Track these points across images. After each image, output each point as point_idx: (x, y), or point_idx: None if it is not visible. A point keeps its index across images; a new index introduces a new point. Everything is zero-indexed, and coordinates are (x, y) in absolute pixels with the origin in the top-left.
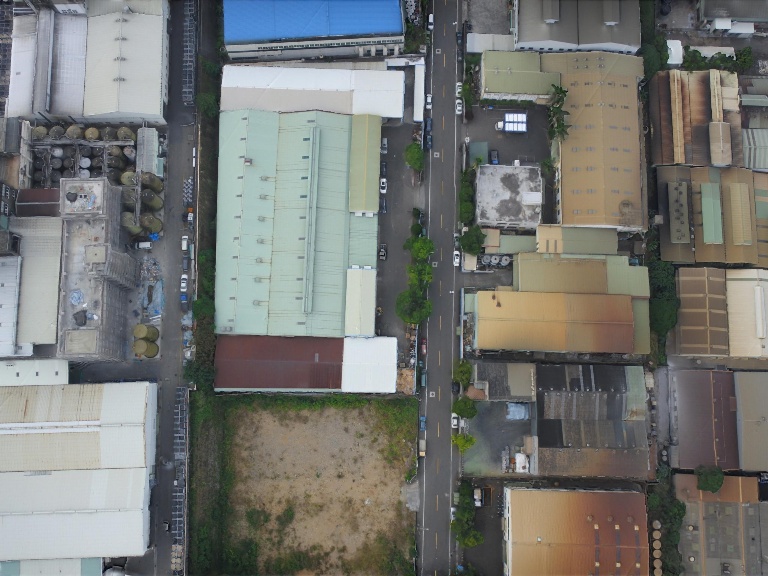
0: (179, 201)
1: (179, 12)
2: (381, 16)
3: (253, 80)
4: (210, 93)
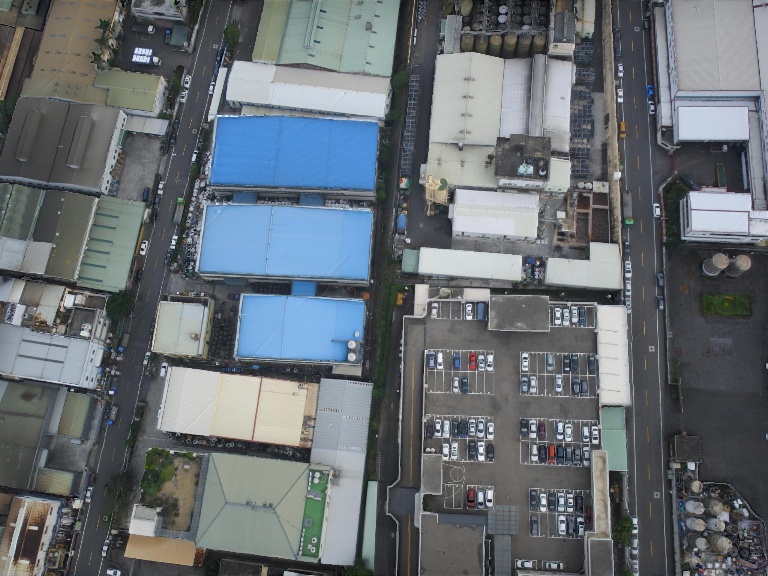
0: (431, 5)
1: (419, 166)
2: (234, 135)
3: (358, 100)
4: (398, 96)
